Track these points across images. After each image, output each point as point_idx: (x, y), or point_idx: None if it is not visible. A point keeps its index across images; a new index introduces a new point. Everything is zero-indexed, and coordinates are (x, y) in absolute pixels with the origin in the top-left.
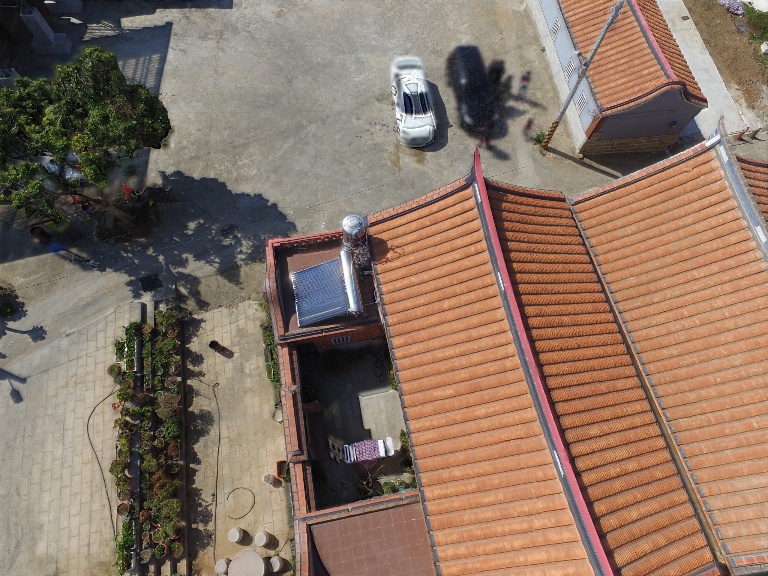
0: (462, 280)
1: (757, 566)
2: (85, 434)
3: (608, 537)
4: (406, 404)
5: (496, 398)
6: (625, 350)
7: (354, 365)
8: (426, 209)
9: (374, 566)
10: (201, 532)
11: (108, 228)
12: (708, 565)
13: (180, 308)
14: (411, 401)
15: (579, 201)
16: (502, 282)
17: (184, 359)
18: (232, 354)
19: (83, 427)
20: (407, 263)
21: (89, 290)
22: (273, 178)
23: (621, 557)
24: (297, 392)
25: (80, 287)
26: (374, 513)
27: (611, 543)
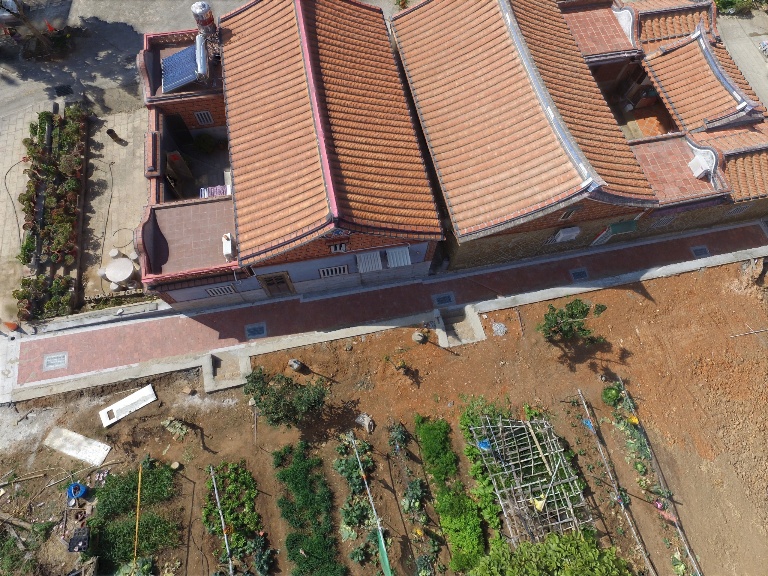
0: (278, 46)
1: (474, 234)
2: (3, 183)
3: (347, 186)
4: (230, 130)
5: (289, 116)
6: (406, 106)
7: (223, 151)
8: (260, 3)
9: (198, 233)
10: (91, 255)
11: (31, 50)
12: (434, 227)
13: (87, 111)
14: (234, 127)
15: (396, 17)
16: (300, 38)
17: (88, 146)
18: (127, 143)
19: (1, 179)
20: (243, 42)
21: (13, 92)
22: (172, 23)
23: (353, 195)
24: (157, 135)
25: (6, 90)
26: (203, 204)
27: (348, 188)
